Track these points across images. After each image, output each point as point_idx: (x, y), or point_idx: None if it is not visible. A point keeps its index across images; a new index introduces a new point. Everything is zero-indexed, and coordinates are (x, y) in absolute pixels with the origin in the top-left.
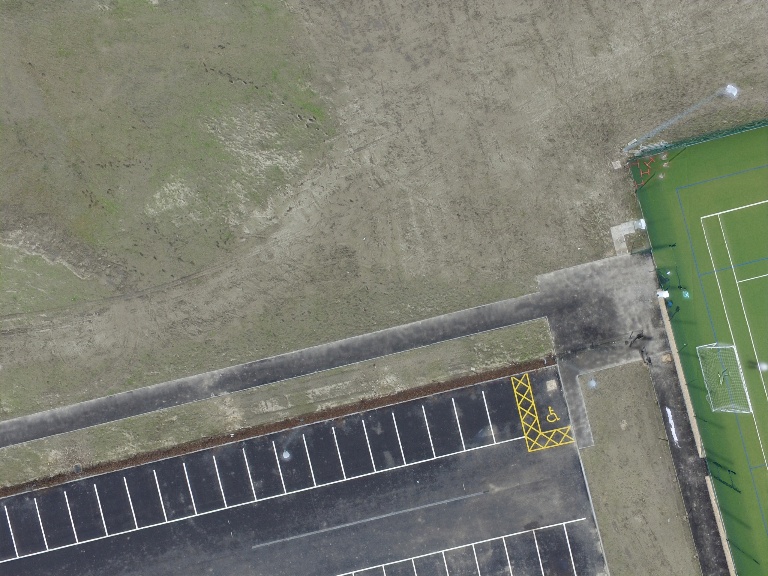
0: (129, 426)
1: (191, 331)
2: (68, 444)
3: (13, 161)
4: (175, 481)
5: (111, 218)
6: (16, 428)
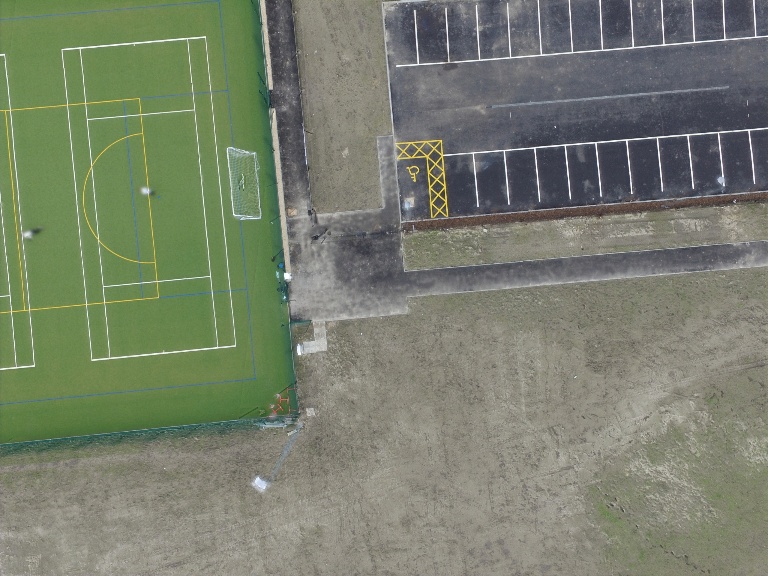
0: None
1: (761, 311)
2: None
3: None
4: None
5: None
6: None
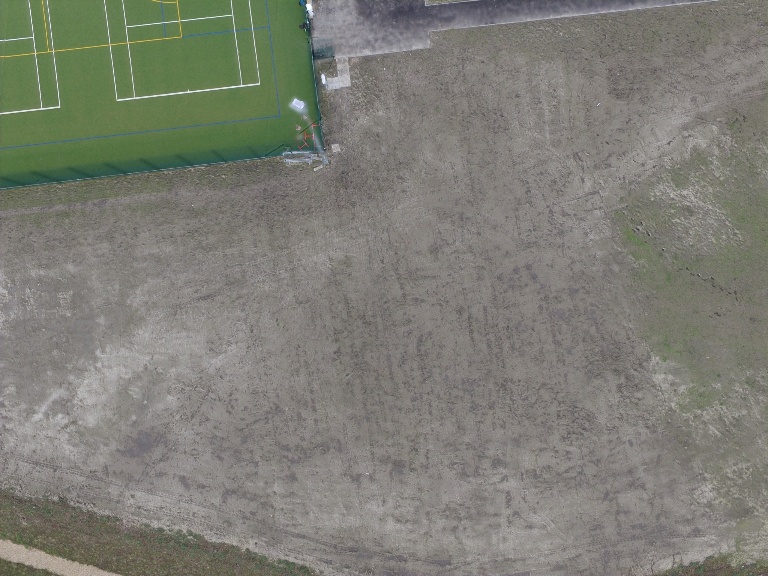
0: None
1: None
2: None
3: None
4: None
5: None
6: None
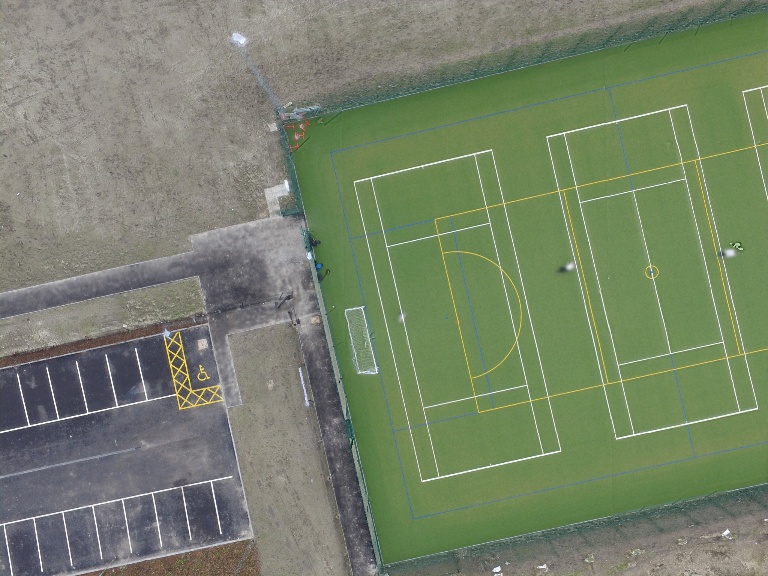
0: None
1: None
2: None
3: None
4: None
5: None
6: None
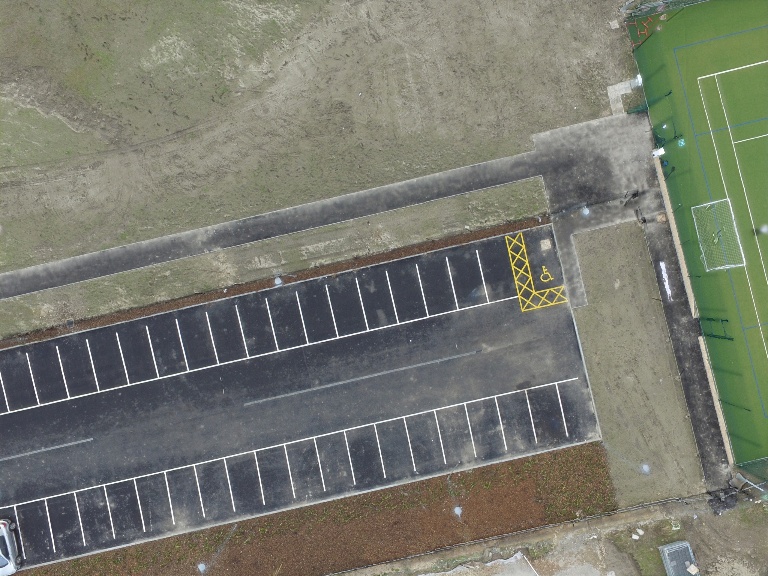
0: (122, 281)
1: (185, 186)
2: (61, 298)
3: (8, 13)
4: (167, 337)
5: (106, 71)
6: (9, 282)
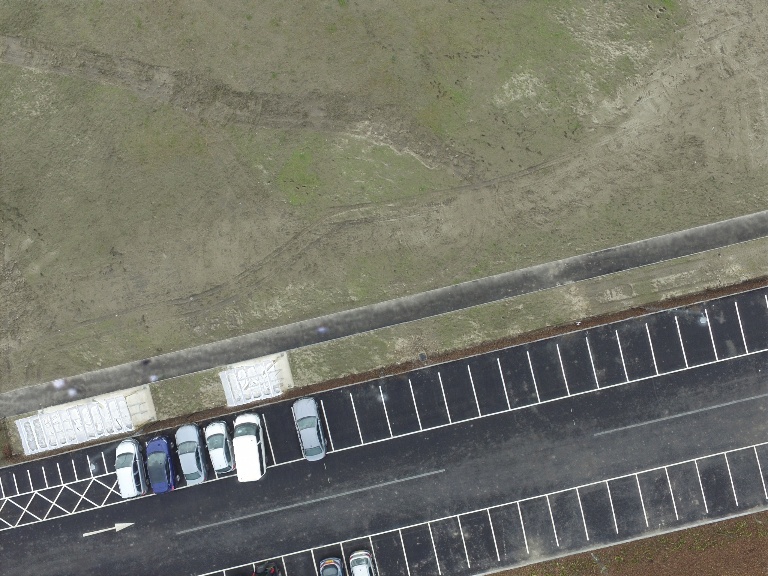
0: (475, 314)
1: (538, 220)
2: (414, 332)
3: (362, 52)
4: (519, 369)
5: (459, 109)
6: (362, 317)
